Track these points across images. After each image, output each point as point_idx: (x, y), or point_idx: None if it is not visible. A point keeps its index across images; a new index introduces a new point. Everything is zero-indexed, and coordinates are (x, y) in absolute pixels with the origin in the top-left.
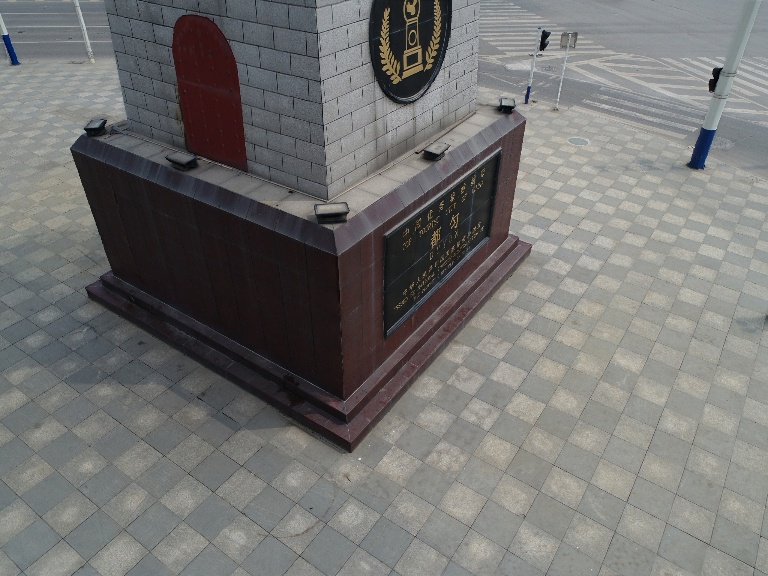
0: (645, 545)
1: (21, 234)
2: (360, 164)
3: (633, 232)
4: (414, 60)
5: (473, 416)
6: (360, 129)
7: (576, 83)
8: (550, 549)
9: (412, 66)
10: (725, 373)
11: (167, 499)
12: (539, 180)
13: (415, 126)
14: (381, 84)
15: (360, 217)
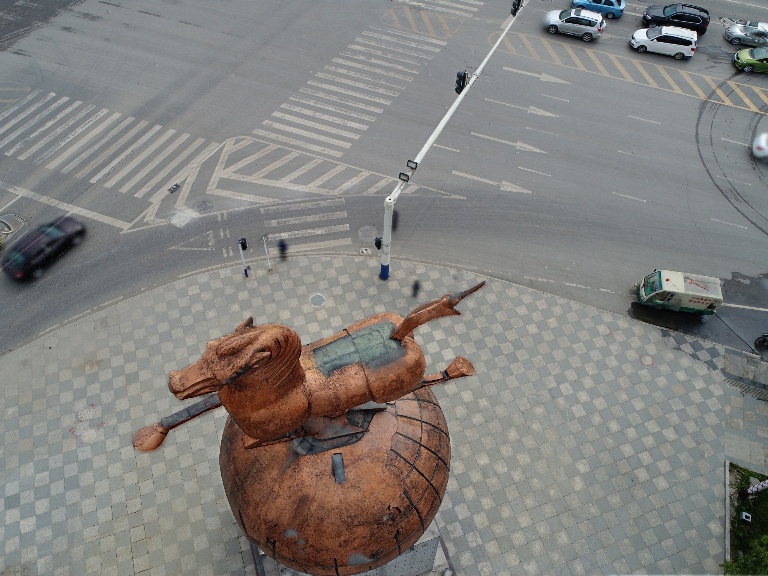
0: (549, 534)
1: None
2: None
3: None
4: None
5: (473, 543)
6: None
7: (241, 215)
8: (535, 564)
9: None
10: (508, 432)
11: None
12: None
13: None
14: None
15: (449, 564)
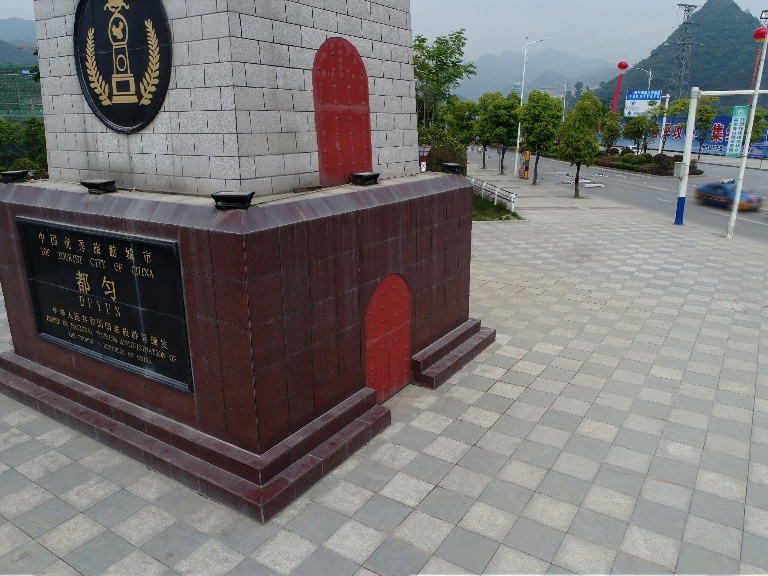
0: None
1: None
2: (74, 167)
3: None
4: (126, 88)
5: None
6: (73, 133)
7: None
8: None
9: (124, 94)
10: None
11: None
12: None
13: (133, 164)
14: (86, 98)
15: None
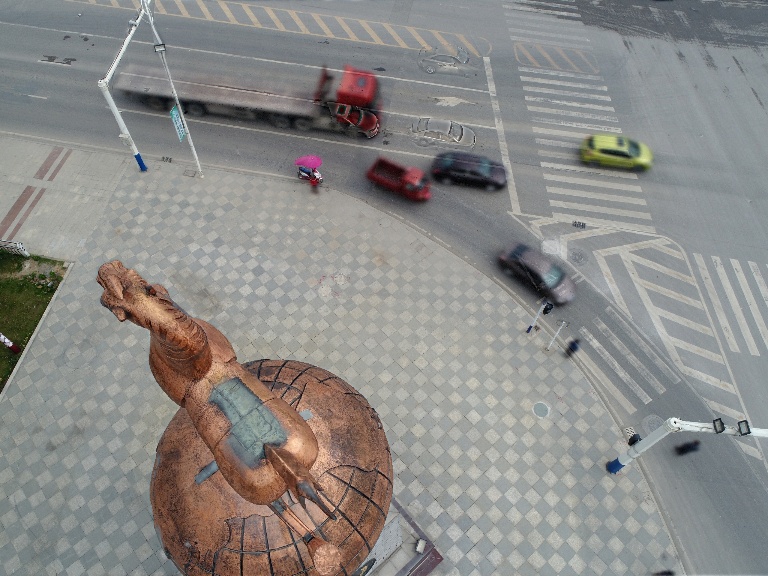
0: None
1: (151, 459)
2: None
3: (519, 550)
4: None
5: None
6: None
7: (590, 293)
8: None
9: None
10: None
11: None
12: (486, 466)
13: None
14: None
15: None
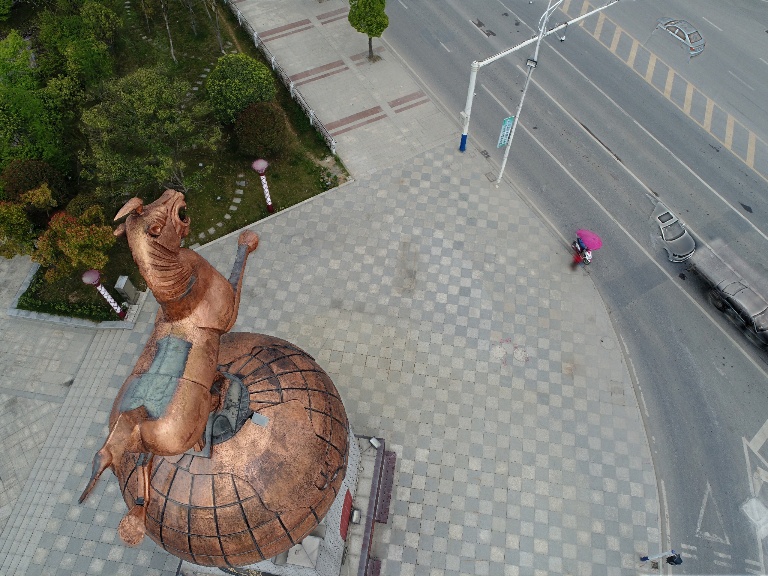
0: None
1: None
2: None
3: None
4: None
5: None
6: None
7: None
8: None
9: None
10: None
11: (141, 552)
12: None
13: None
14: (230, 573)
15: None
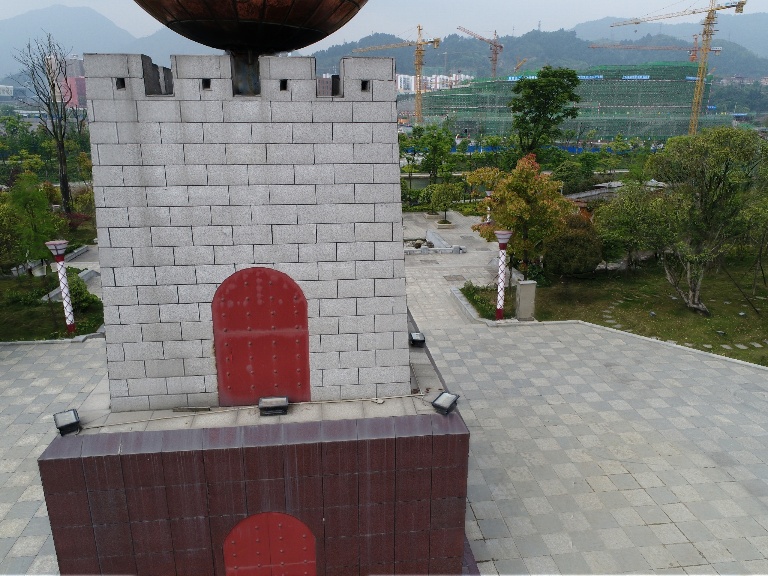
0: None
1: (553, 414)
2: None
3: None
4: None
5: None
6: None
7: None
8: None
9: None
10: None
11: None
12: None
13: None
14: None
15: None
